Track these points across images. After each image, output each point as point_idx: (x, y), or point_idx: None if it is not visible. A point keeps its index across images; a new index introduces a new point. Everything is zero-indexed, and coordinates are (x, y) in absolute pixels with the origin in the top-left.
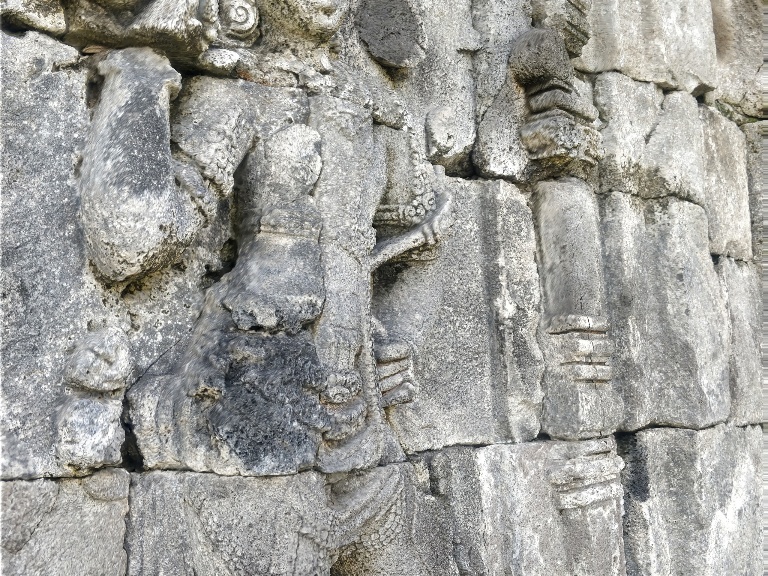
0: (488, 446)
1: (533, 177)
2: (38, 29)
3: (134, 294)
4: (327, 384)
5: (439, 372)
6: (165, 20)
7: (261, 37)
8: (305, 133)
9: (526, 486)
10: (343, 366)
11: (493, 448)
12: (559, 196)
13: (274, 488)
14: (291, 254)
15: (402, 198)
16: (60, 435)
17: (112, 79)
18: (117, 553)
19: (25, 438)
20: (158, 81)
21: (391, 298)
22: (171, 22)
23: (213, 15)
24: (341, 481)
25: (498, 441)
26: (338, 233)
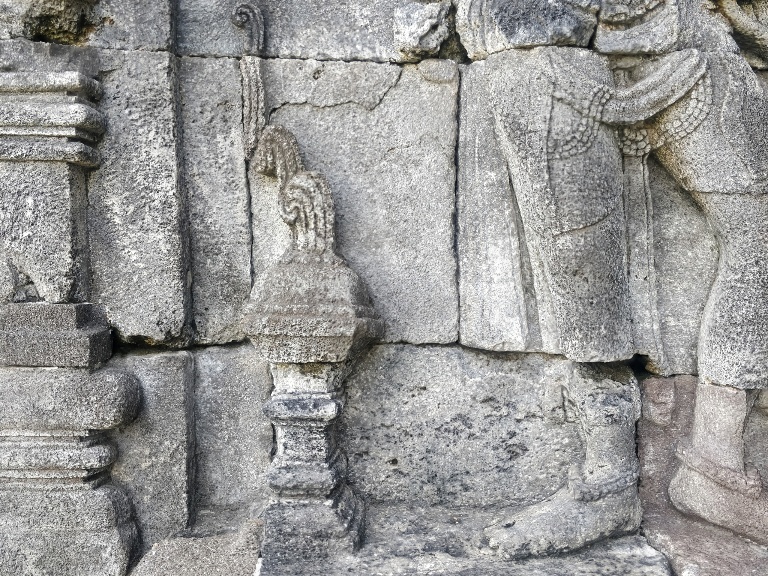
0: None
1: None
2: None
3: None
4: None
5: None
6: None
7: None
8: None
9: None
10: None
11: None
12: None
13: (531, 58)
14: None
15: None
16: (393, 29)
17: None
18: (448, 123)
19: (373, 32)
20: None
21: None
22: None
23: None
24: (637, 67)
25: None
26: None
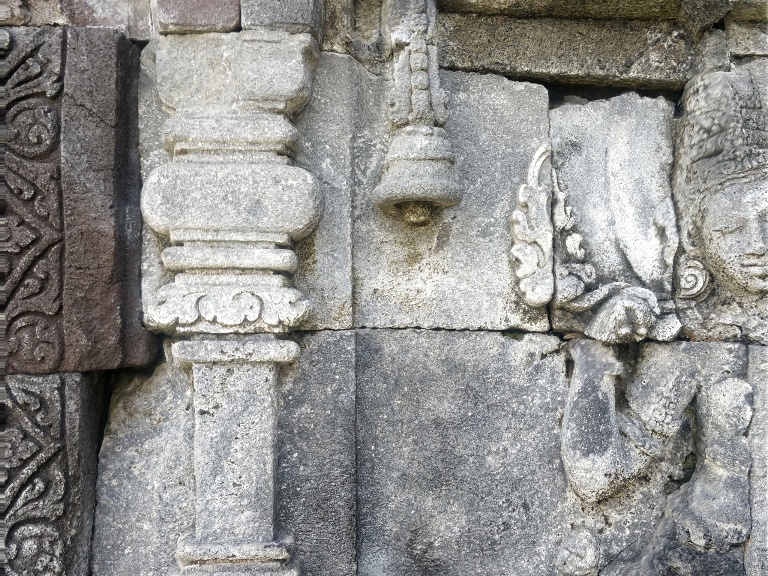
0: None
1: None
2: (532, 332)
3: (608, 501)
4: None
5: None
6: (600, 334)
7: (714, 290)
8: (737, 386)
9: None
10: None
11: None
12: None
13: None
14: (725, 485)
15: None
16: None
17: (576, 366)
18: None
19: None
20: (601, 372)
21: None
22: (604, 336)
23: (639, 321)
24: None
25: None
26: (765, 472)
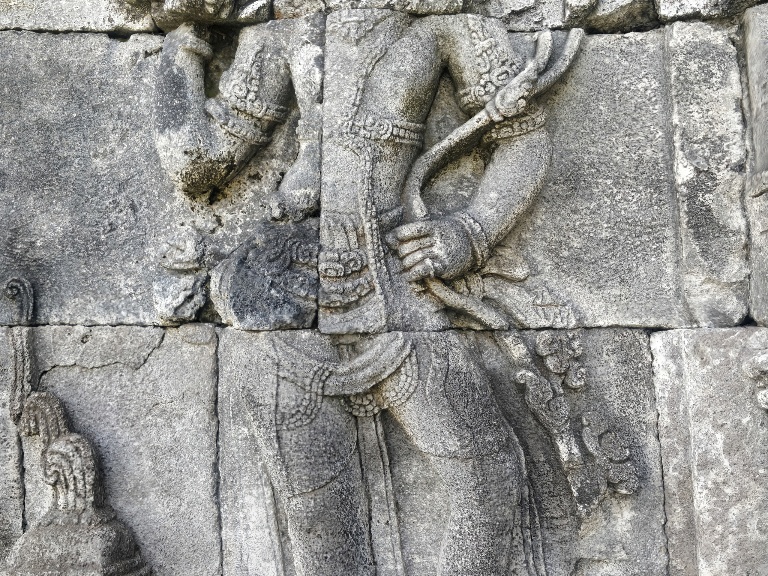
0: (670, 330)
1: (737, 5)
2: (138, 31)
3: (220, 201)
4: (318, 261)
5: (585, 250)
6: (167, 3)
7: None
8: (309, 51)
9: (704, 376)
10: (341, 245)
11: (676, 332)
12: (762, 21)
13: None
14: None
15: (472, 80)
16: None
17: None
18: (207, 380)
19: (137, 300)
20: None
21: (481, 179)
22: (169, 3)
23: None
24: (357, 343)
25: (682, 325)
26: (332, 132)
